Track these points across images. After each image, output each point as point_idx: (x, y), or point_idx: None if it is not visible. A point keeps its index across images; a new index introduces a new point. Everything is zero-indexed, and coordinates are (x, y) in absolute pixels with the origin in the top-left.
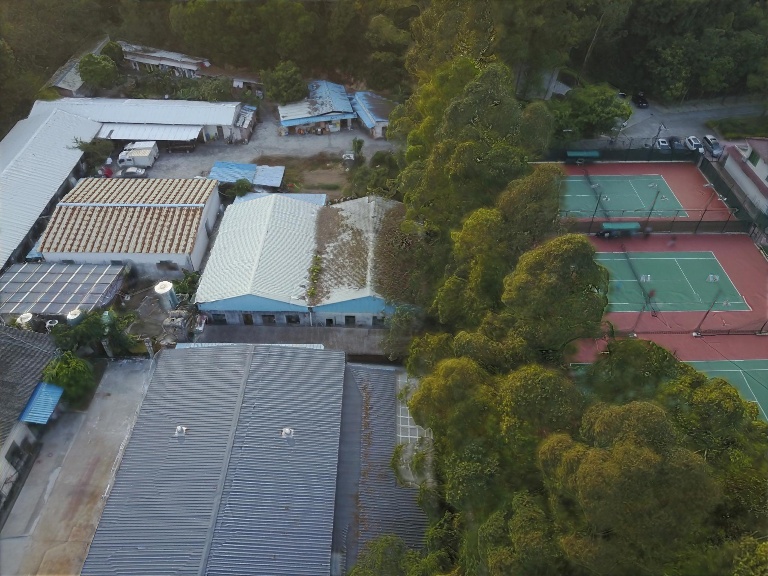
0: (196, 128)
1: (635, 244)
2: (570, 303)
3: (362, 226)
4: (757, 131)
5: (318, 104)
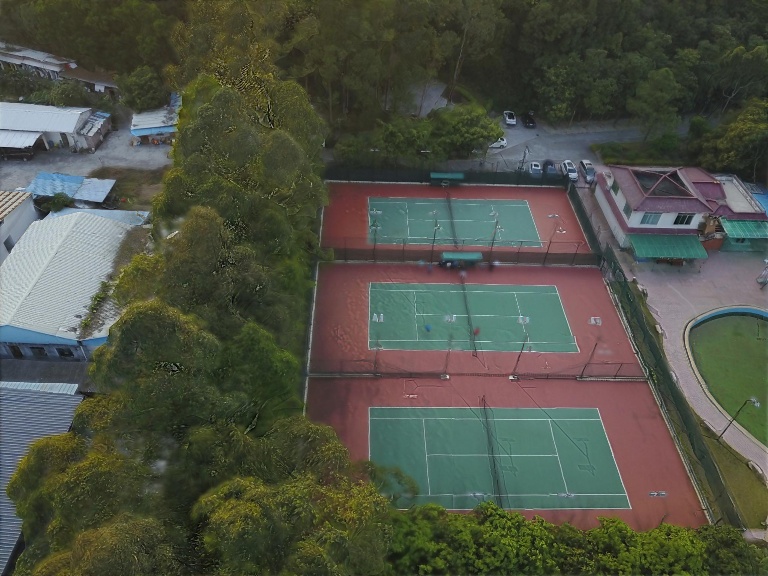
0: (34, 135)
1: (478, 275)
2: (138, 383)
3: None
4: (638, 157)
5: (175, 113)
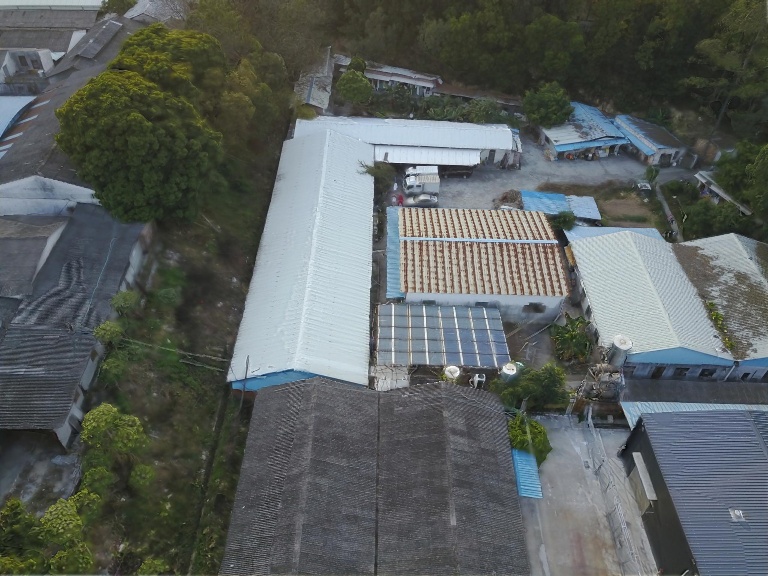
0: (475, 152)
1: None
2: None
3: (743, 269)
4: None
5: (586, 128)
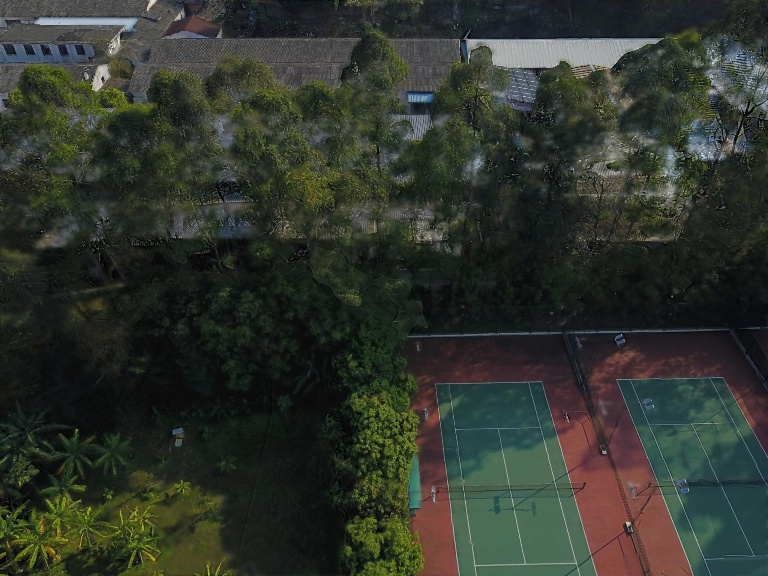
0: None
1: None
2: None
3: None
4: None
5: None
